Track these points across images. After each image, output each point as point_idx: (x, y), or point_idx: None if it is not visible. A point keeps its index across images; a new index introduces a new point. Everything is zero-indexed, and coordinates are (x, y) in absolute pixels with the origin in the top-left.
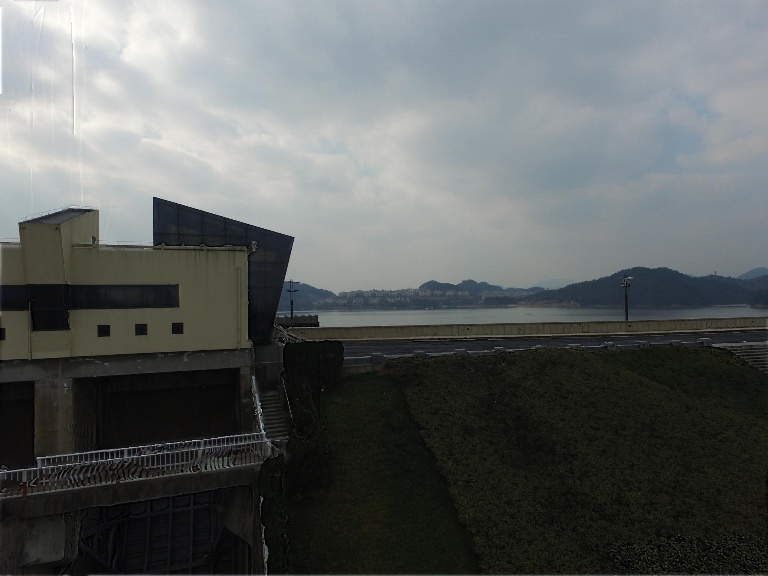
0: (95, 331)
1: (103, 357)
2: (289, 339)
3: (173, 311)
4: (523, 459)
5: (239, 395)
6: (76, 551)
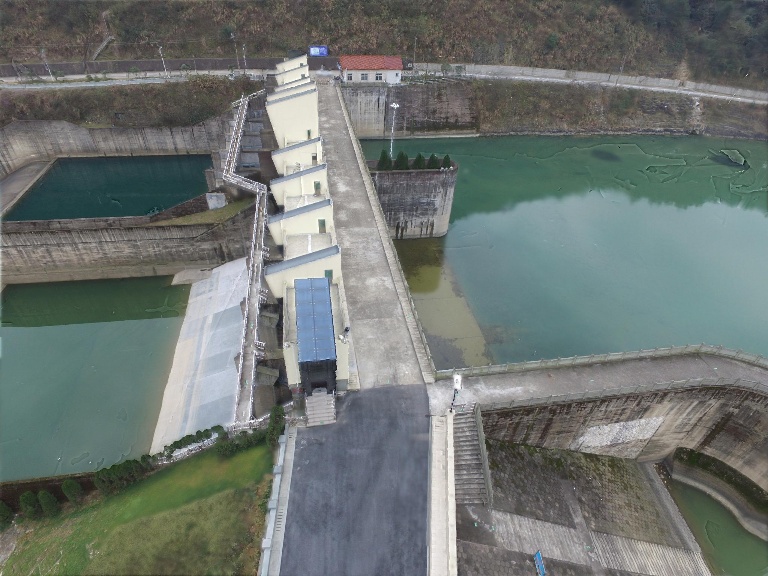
0: None
1: None
2: None
3: None
4: (161, 558)
5: None
6: (272, 384)
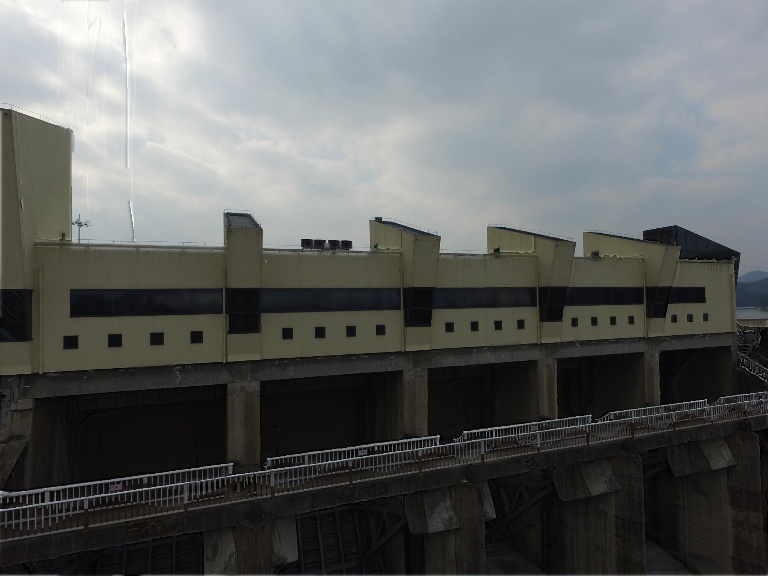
0: (670, 319)
1: (672, 337)
2: (737, 326)
3: (703, 305)
4: None
5: (695, 367)
6: None
